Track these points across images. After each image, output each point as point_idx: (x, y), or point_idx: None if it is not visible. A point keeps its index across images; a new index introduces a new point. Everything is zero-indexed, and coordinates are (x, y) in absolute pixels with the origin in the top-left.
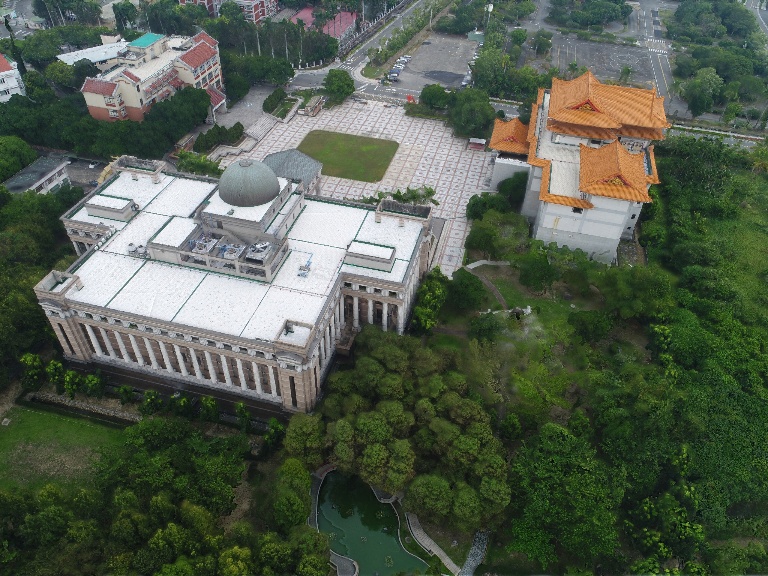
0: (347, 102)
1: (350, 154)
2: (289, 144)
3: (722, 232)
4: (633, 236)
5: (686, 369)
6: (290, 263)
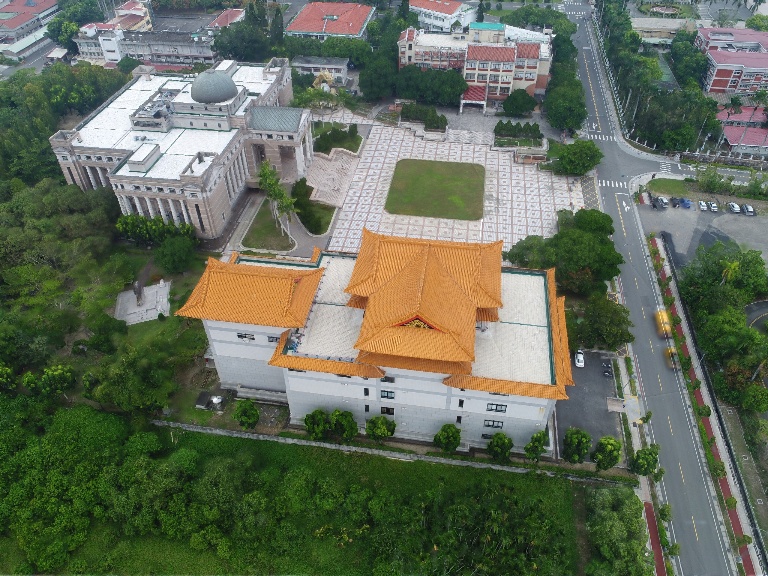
0: (565, 178)
1: (438, 190)
2: (445, 156)
3: (330, 574)
4: (298, 426)
5: None
6: (153, 134)
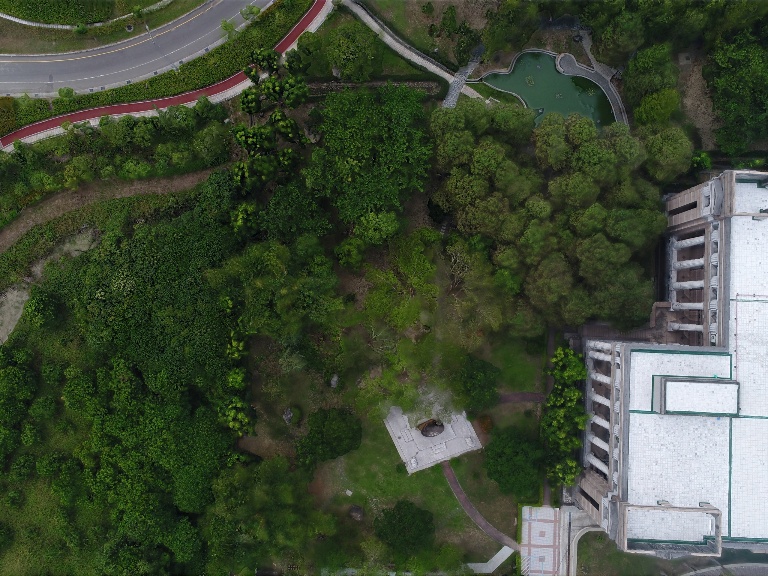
0: None
1: None
2: None
3: None
4: None
5: (205, 405)
6: None
